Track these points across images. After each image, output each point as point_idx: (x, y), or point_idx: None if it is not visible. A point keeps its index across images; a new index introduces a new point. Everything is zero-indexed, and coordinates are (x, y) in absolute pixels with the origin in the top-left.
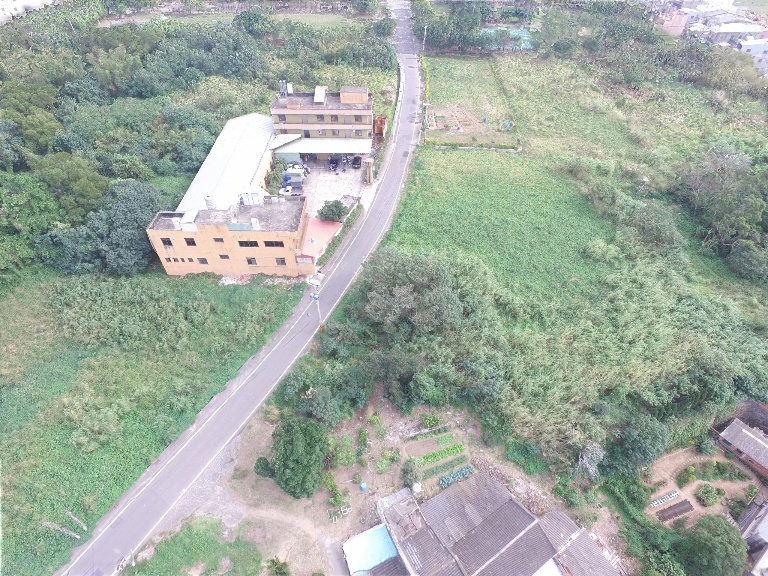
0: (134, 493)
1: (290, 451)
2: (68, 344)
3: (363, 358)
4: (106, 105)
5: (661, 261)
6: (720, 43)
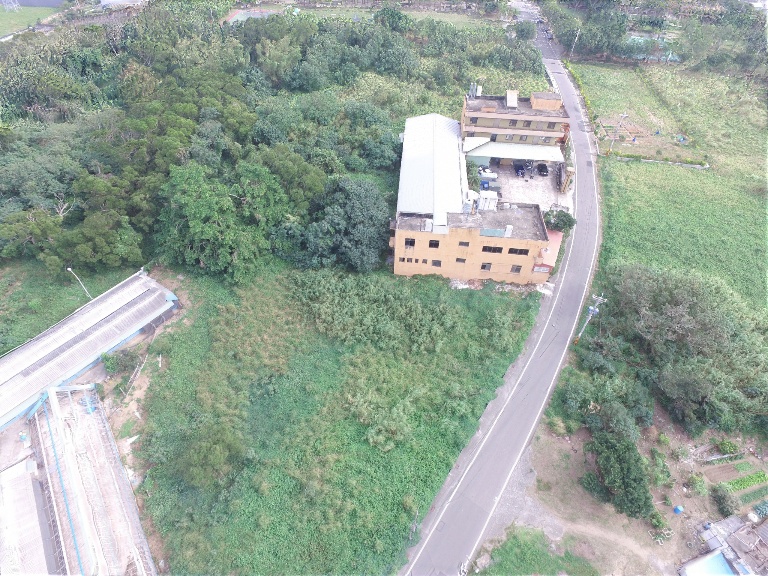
0: (446, 497)
1: (626, 469)
2: (322, 338)
3: (628, 375)
4: (271, 96)
5: None
6: None
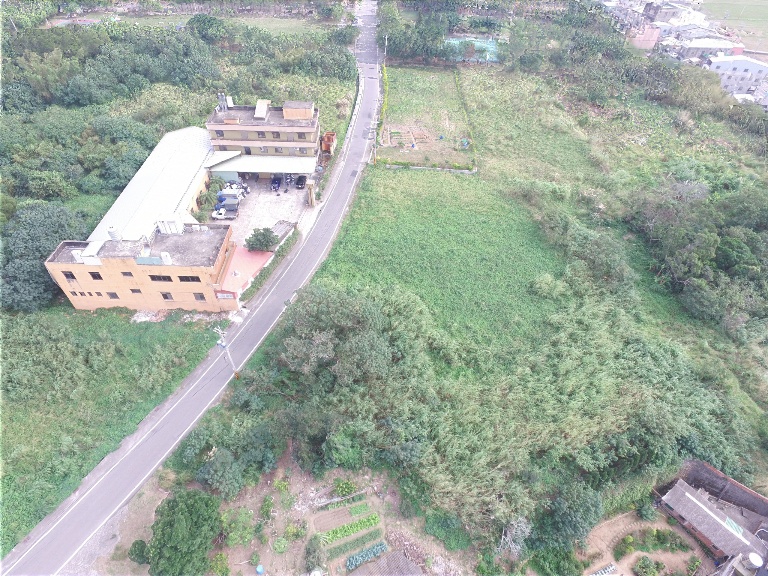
0: None
1: (169, 535)
2: None
3: None
4: None
5: (610, 299)
6: (691, 58)
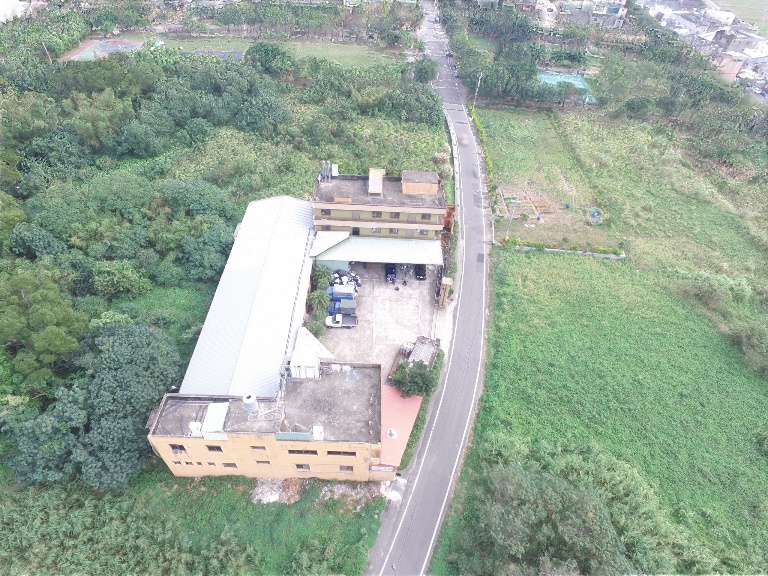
0: None
1: None
2: None
3: None
4: (86, 167)
5: None
6: None
